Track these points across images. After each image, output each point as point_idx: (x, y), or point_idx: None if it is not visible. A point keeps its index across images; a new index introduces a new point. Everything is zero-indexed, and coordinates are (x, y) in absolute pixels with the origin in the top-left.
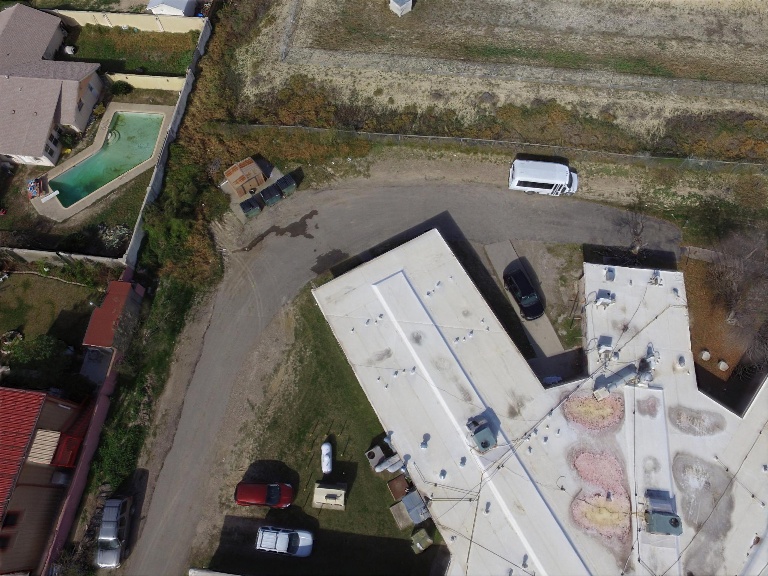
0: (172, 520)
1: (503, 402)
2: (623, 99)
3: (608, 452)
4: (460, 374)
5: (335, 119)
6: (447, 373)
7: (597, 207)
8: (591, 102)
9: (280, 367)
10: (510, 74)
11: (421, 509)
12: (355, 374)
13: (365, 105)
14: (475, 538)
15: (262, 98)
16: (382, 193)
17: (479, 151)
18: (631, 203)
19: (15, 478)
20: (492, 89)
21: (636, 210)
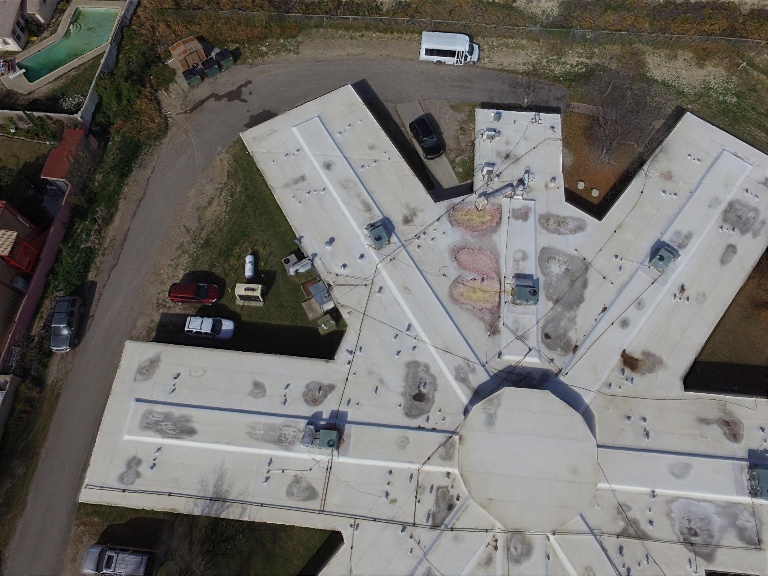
0: (116, 317)
1: (398, 213)
2: None
3: (485, 248)
4: (363, 192)
5: (269, 6)
6: (352, 191)
7: (496, 74)
8: None
9: (213, 201)
10: None
11: (324, 294)
12: (274, 195)
13: None
14: (368, 312)
15: None
16: (309, 66)
17: (395, 30)
18: (526, 70)
19: None
20: None
21: (530, 75)
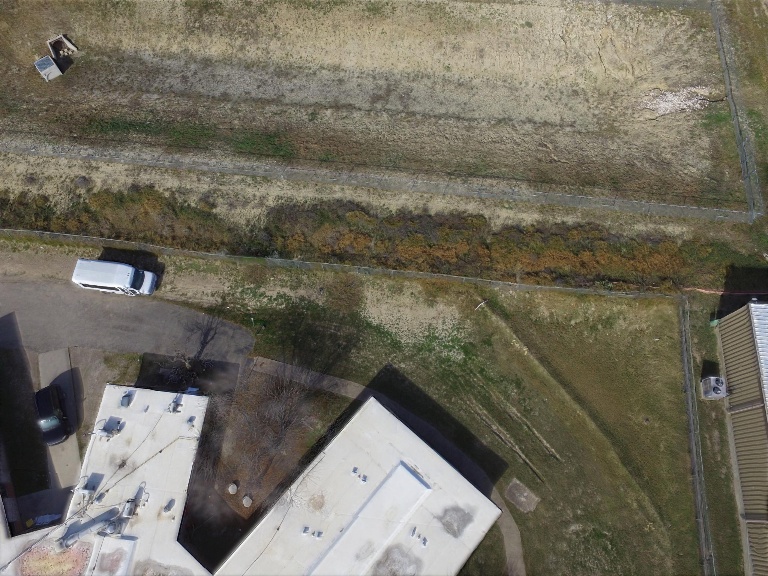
0: None
1: None
2: (226, 185)
3: None
4: None
5: None
6: None
7: (174, 309)
8: (191, 188)
9: None
10: (115, 155)
11: None
12: None
13: None
14: None
15: None
16: None
17: (64, 243)
18: (213, 304)
19: None
20: (90, 173)
21: (215, 313)
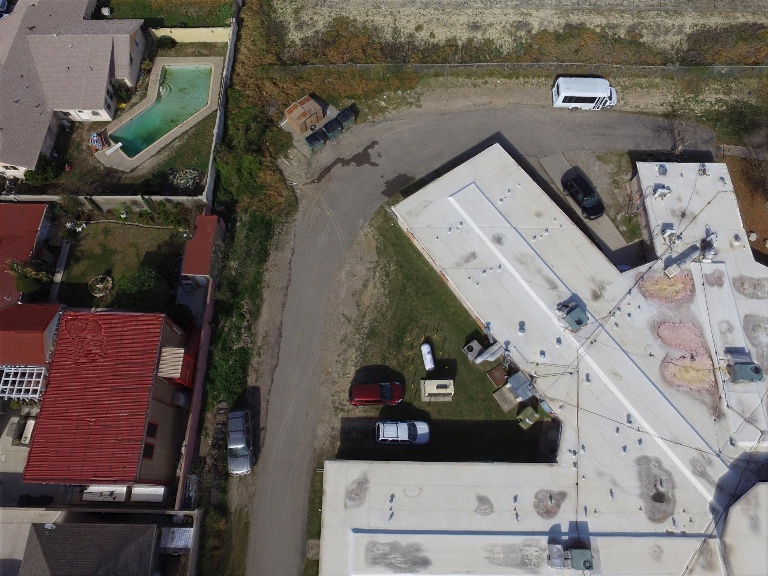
0: (291, 427)
1: (585, 287)
2: (646, 19)
3: (685, 320)
4: (543, 267)
5: (382, 55)
6: (531, 267)
7: (636, 117)
8: (618, 23)
9: (368, 283)
10: (540, 3)
11: (527, 386)
12: (446, 277)
13: (408, 41)
14: (581, 405)
15: (308, 41)
16: (436, 120)
17: (521, 75)
18: (665, 112)
19: (150, 391)
20: (525, 18)
21: (671, 117)
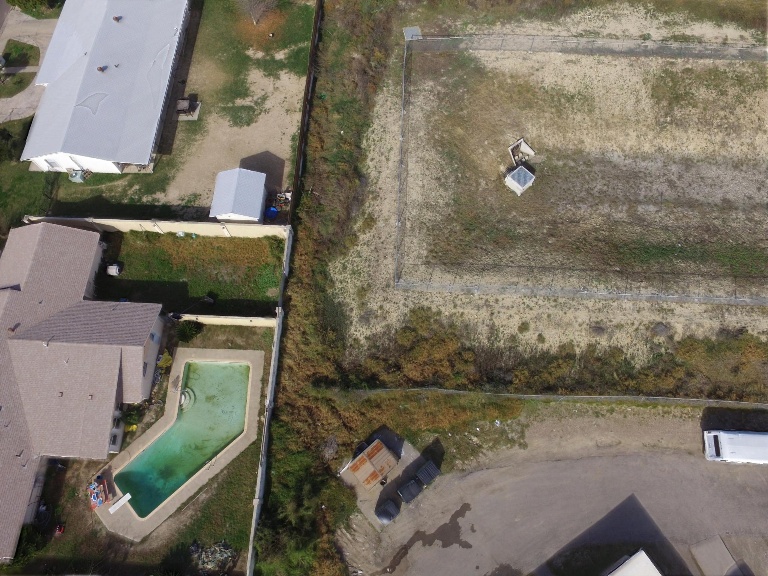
0: None
1: None
2: None
3: None
4: None
5: (475, 370)
6: None
7: None
8: None
9: None
10: (684, 293)
11: None
12: None
13: (509, 346)
14: None
15: (376, 341)
16: (547, 471)
17: (660, 405)
18: None
19: None
20: (666, 317)
21: None
